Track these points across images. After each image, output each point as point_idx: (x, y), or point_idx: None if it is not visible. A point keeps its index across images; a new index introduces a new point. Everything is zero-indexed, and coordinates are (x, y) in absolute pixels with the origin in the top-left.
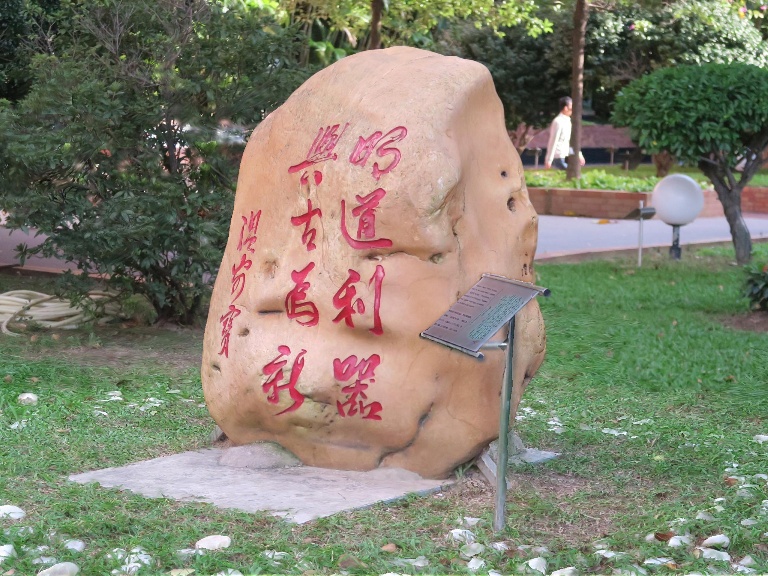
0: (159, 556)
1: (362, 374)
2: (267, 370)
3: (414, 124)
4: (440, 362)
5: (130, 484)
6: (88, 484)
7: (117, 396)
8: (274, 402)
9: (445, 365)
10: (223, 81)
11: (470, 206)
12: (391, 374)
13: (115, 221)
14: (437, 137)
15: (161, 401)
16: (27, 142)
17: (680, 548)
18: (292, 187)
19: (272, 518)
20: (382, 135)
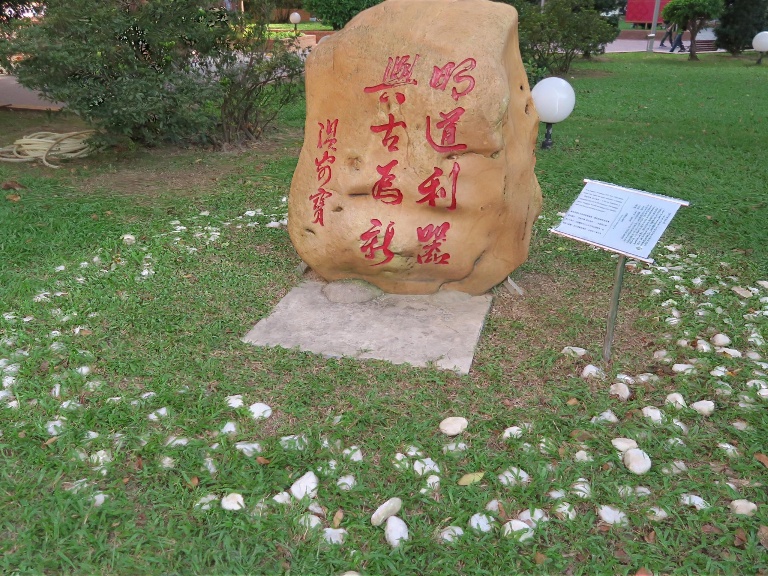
0: (444, 462)
1: (437, 236)
2: (364, 237)
3: (481, 56)
4: (492, 224)
5: (299, 340)
6: (273, 349)
7: (181, 226)
8: (370, 258)
9: (495, 226)
10: (168, 1)
11: (510, 114)
12: (458, 235)
13: (132, 100)
14: (498, 66)
15: (216, 229)
16: (62, 50)
17: (712, 352)
18: (371, 104)
19: (451, 374)
20: (456, 65)
